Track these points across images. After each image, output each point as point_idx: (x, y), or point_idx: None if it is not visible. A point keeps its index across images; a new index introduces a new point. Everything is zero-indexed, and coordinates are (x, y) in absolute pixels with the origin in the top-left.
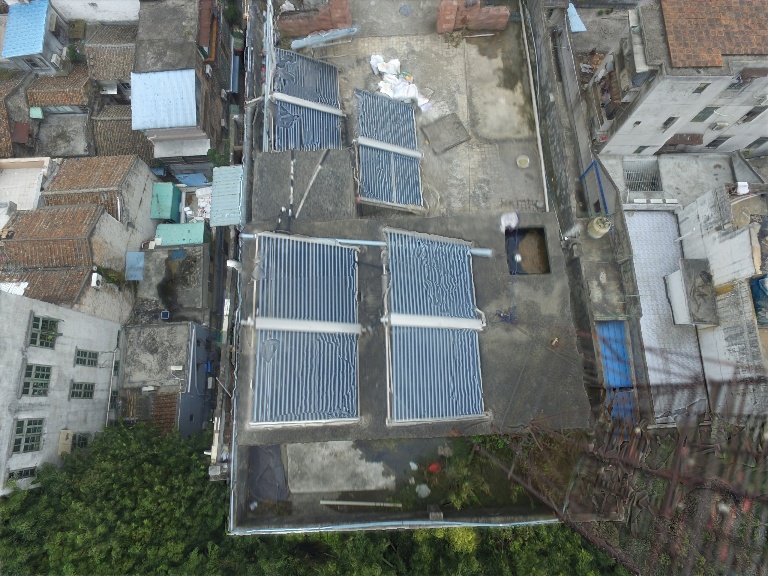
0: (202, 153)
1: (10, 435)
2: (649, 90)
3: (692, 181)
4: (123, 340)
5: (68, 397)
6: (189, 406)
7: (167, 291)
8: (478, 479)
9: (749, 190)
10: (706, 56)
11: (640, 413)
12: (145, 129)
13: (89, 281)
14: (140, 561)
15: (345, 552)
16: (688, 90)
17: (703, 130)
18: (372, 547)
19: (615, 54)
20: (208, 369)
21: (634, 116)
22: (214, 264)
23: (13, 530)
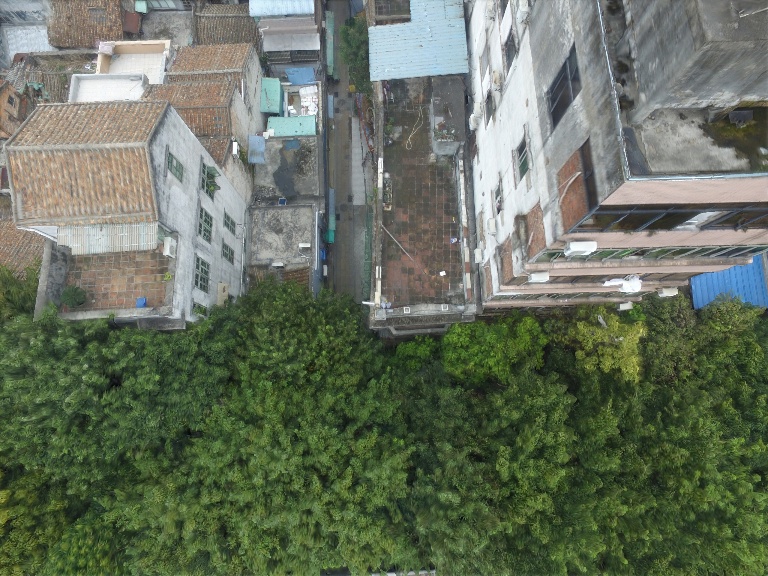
0: (311, 48)
1: (193, 267)
2: None
3: None
4: (248, 221)
5: (221, 254)
6: (315, 284)
7: (283, 179)
8: None
9: None
10: None
11: None
12: (260, 18)
13: (230, 149)
14: (320, 389)
15: (522, 379)
16: None
17: None
18: (542, 379)
19: None
20: (324, 257)
21: None
22: None
23: (204, 352)
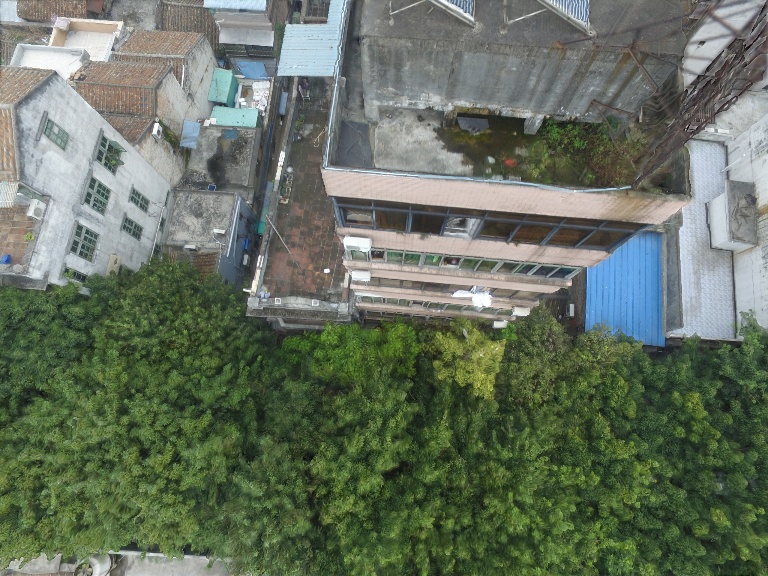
0: (265, 44)
1: (70, 234)
2: (721, 1)
3: (746, 118)
4: (171, 202)
5: (120, 227)
6: (226, 270)
7: (216, 166)
8: (551, 177)
9: None
10: None
11: (667, 320)
12: (215, 10)
13: (151, 129)
14: (176, 367)
15: (371, 381)
16: (760, 4)
17: (765, 65)
18: (396, 385)
19: None
20: (246, 246)
21: (700, 33)
22: (262, 152)
23: (64, 316)
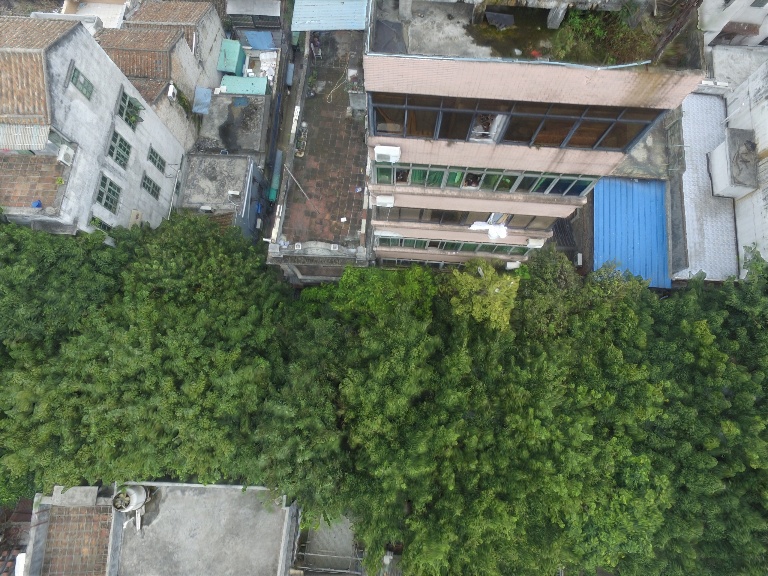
0: (272, 14)
1: (96, 183)
2: None
3: (744, 72)
4: (185, 166)
5: (140, 184)
6: None
7: (228, 133)
8: None
9: None
10: None
11: (673, 263)
12: None
13: (166, 92)
14: None
15: (392, 317)
16: None
17: (761, 19)
18: None
19: None
20: (258, 210)
21: None
22: (272, 120)
23: (94, 261)
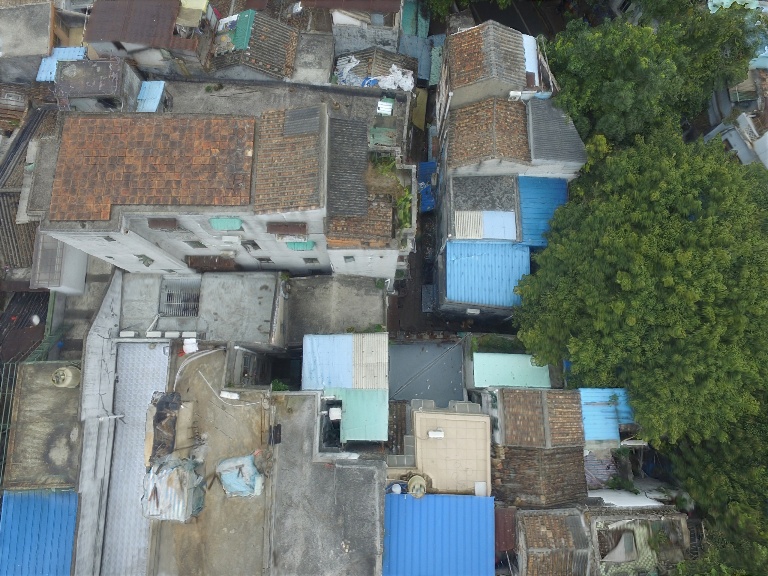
0: None
1: None
2: None
3: (233, 305)
4: None
5: None
6: None
7: None
8: None
9: (201, 347)
10: (91, 207)
11: None
12: None
13: None
14: None
15: None
16: (97, 240)
17: None
18: None
19: None
20: None
21: None
22: None
23: None
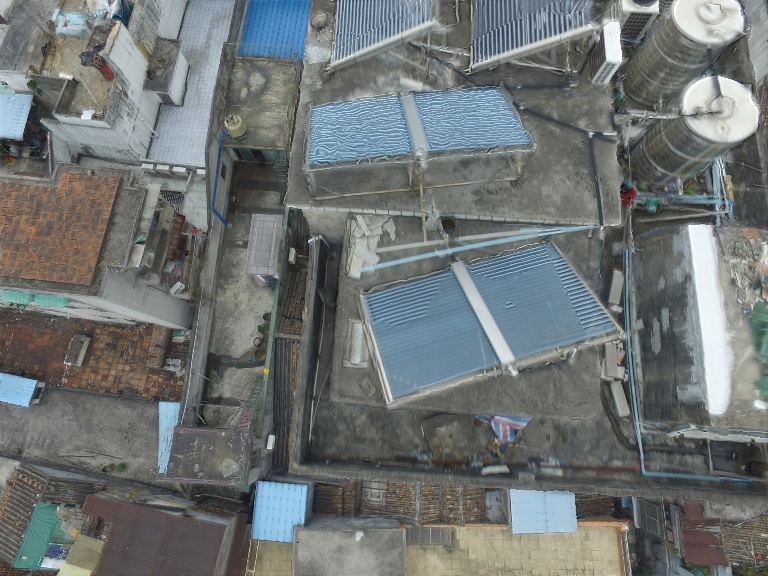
0: None
1: None
2: None
3: None
4: None
5: None
6: None
7: None
8: None
9: None
10: (77, 187)
11: None
12: None
13: None
14: None
15: None
16: None
17: None
18: None
19: (159, 277)
20: None
21: None
22: None
23: None
